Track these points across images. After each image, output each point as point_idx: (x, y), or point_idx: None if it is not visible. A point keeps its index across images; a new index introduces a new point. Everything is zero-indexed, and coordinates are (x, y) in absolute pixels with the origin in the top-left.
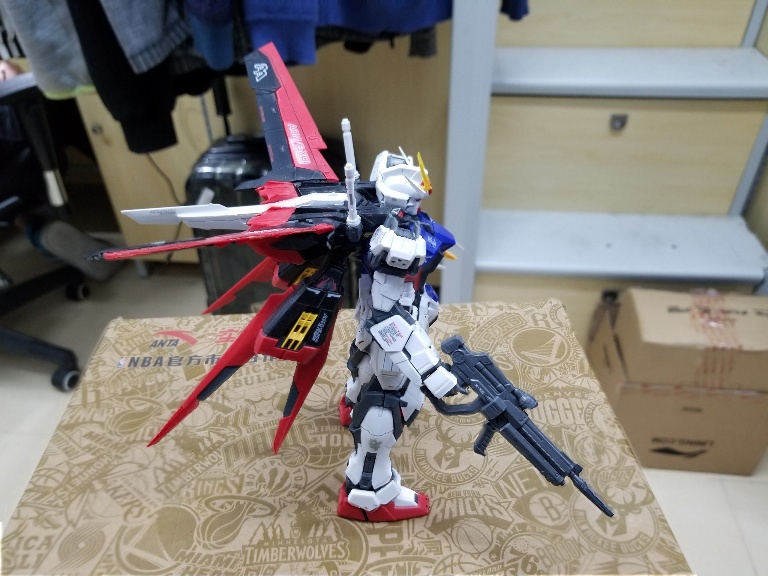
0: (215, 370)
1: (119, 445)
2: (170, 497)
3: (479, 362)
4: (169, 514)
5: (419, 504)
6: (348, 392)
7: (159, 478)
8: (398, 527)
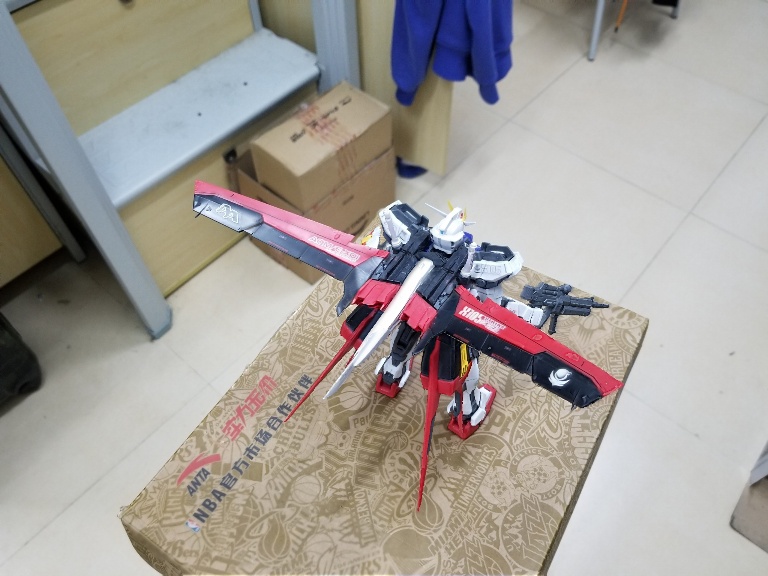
0: (428, 429)
1: (296, 560)
2: (377, 539)
3: (543, 290)
4: (392, 545)
5: (491, 391)
6: (395, 375)
7: (353, 541)
8: (494, 412)
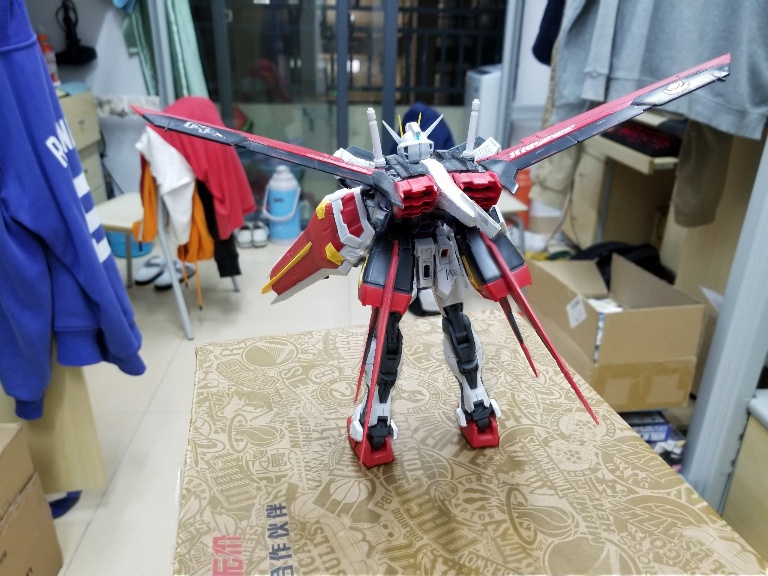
0: None
1: None
2: None
3: None
4: (561, 572)
5: None
6: (389, 415)
7: None
8: None
